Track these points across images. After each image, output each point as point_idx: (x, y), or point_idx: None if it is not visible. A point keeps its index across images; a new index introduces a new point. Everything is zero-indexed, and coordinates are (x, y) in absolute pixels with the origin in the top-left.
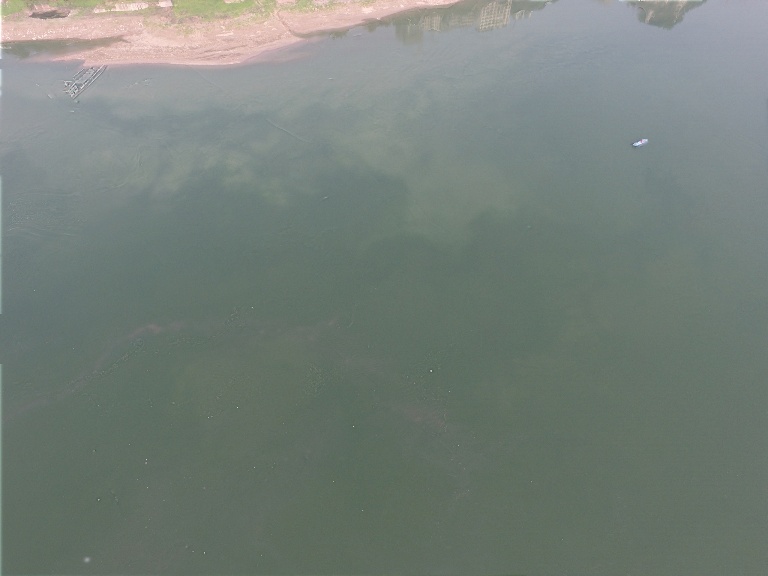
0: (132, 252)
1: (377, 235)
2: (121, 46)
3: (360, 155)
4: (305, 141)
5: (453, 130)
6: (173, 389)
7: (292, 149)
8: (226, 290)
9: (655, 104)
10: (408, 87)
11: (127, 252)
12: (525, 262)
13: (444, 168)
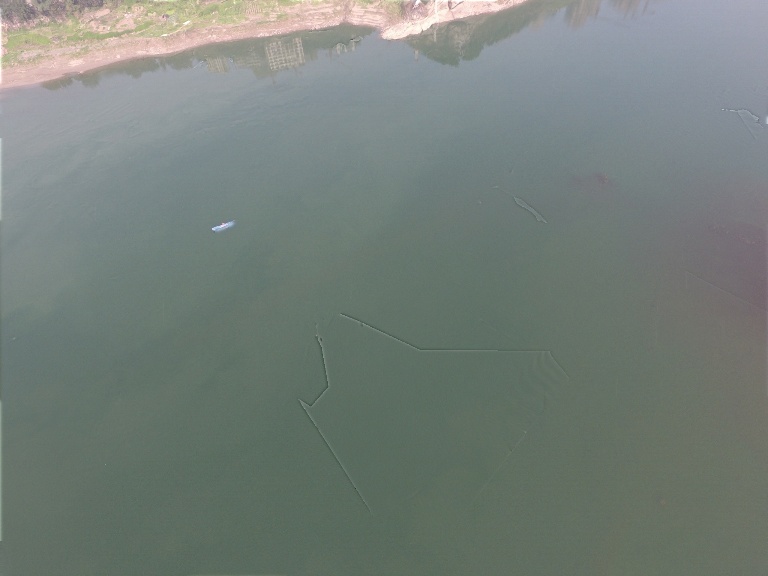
0: None
1: None
2: None
3: None
4: None
5: (48, 208)
6: None
7: None
8: None
9: (320, 167)
10: (43, 155)
11: None
12: None
13: None
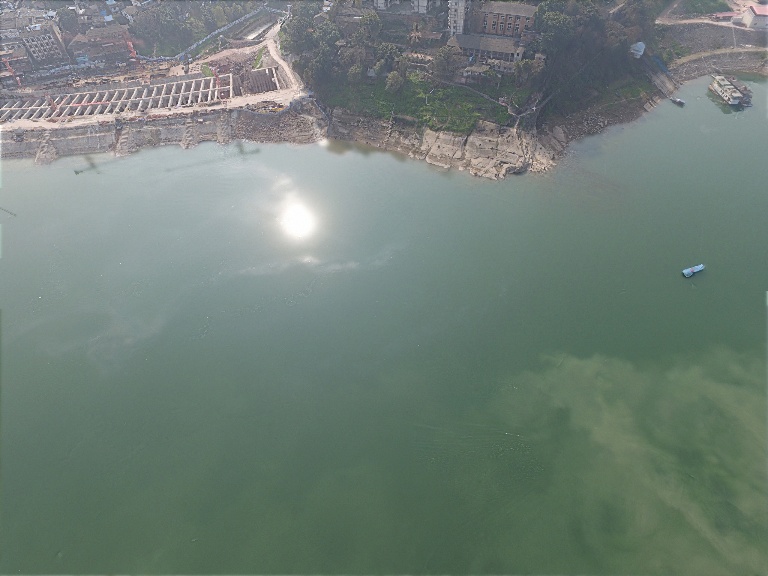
0: (332, 403)
1: (11, 450)
2: None
3: None
4: None
5: None
6: (258, 279)
7: None
8: (219, 369)
9: None
10: None
11: (339, 402)
12: None
13: None
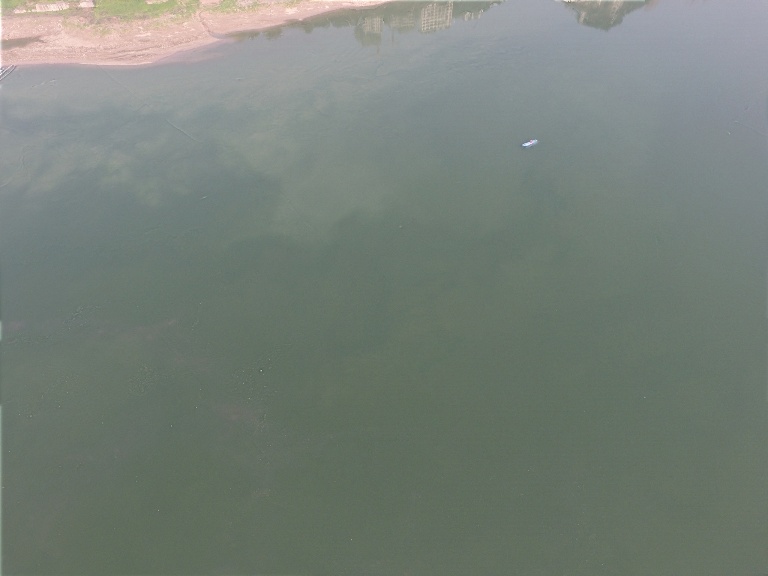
0: None
1: (242, 235)
2: (36, 46)
3: (250, 155)
4: (198, 141)
5: (350, 130)
6: (1, 388)
7: (184, 149)
8: (80, 289)
9: (563, 105)
10: (314, 87)
11: None
12: (387, 262)
13: (331, 168)
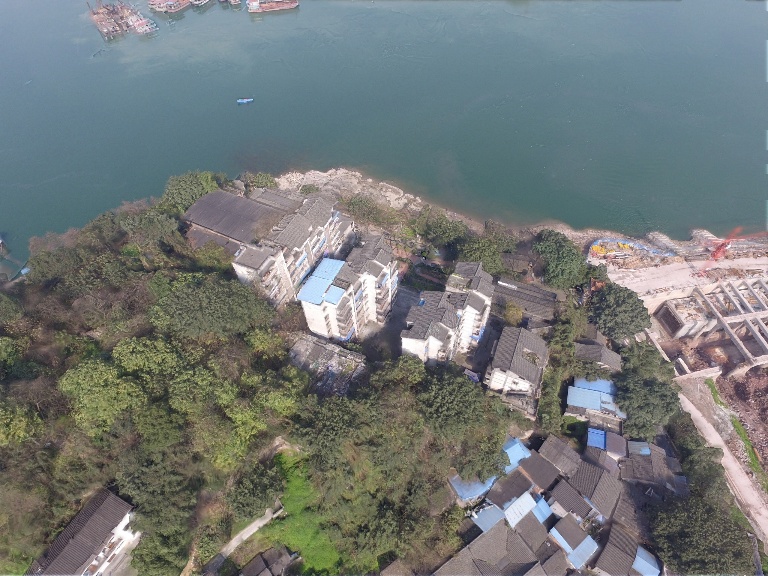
0: (473, 64)
1: (623, 55)
2: None
3: None
4: (542, 19)
5: (639, 14)
6: None
7: (534, 24)
8: None
9: None
10: None
11: (470, 64)
12: (721, 69)
13: (644, 31)
